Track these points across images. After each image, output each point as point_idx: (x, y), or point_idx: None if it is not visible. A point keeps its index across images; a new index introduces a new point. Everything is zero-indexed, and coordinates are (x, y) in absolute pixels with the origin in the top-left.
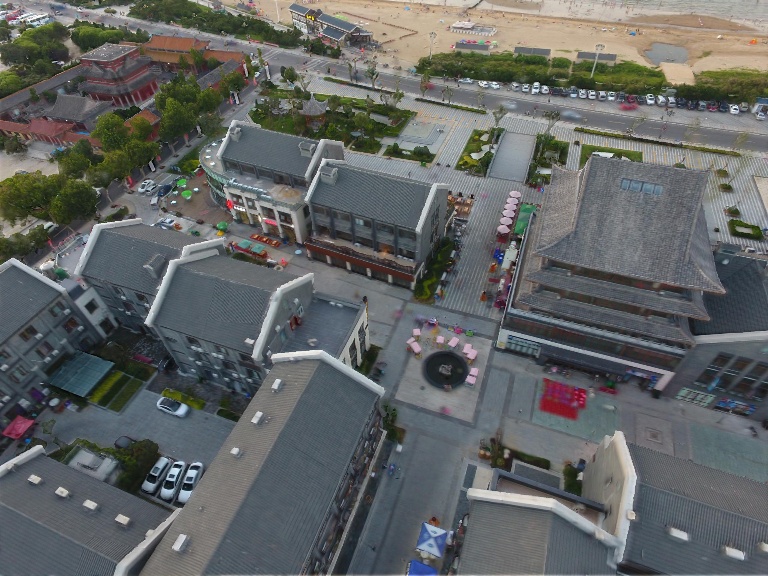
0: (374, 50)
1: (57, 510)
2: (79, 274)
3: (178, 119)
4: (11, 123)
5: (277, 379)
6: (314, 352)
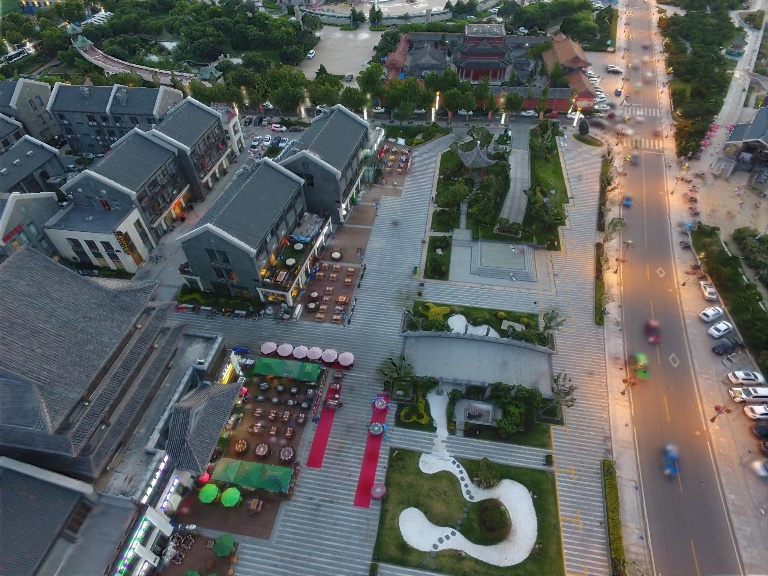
0: (684, 169)
1: (6, 163)
2: (168, 114)
3: (401, 95)
4: (400, 48)
5: None
6: (17, 194)
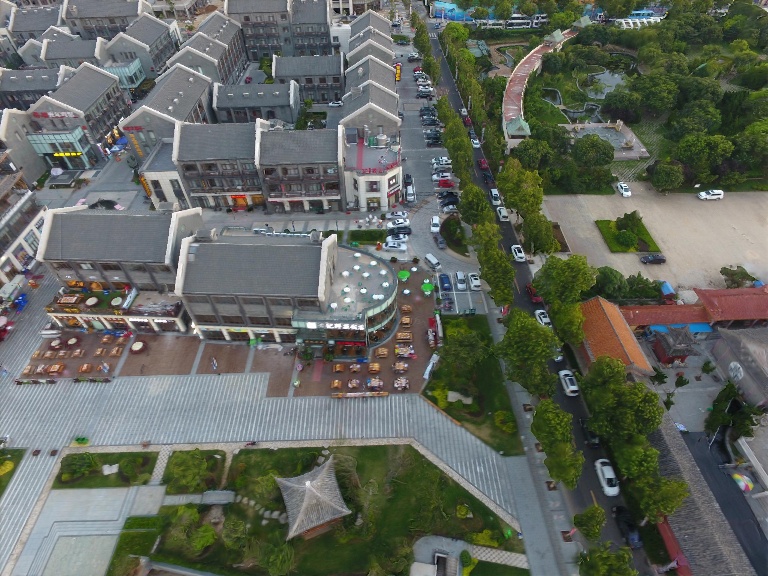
0: None
1: (257, 90)
2: None
3: None
4: None
5: (170, 108)
6: None
